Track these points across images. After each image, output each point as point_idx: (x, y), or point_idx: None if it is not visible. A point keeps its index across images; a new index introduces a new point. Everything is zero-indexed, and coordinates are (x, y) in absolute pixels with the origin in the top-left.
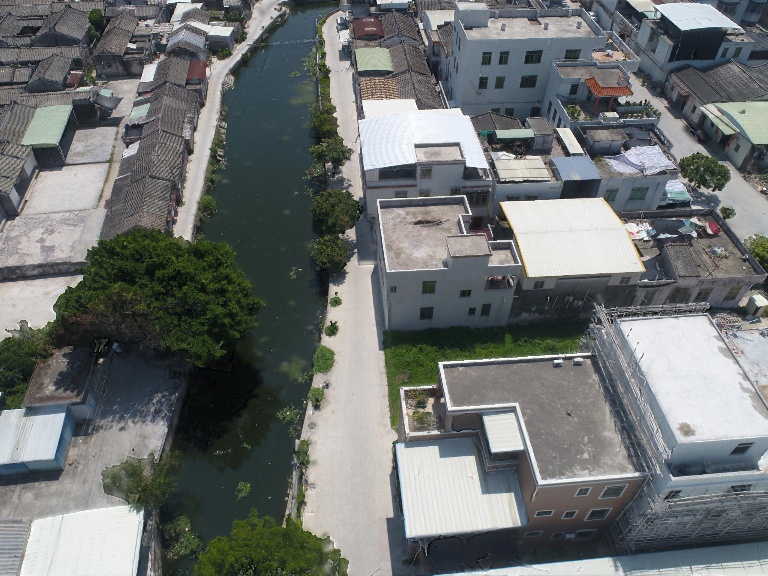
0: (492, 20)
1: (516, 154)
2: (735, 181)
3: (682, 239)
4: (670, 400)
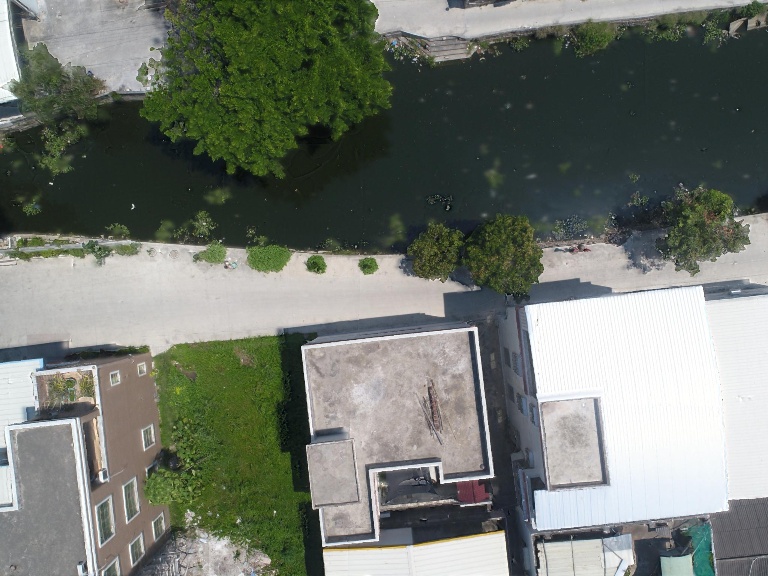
0: None
1: None
2: None
3: None
4: None
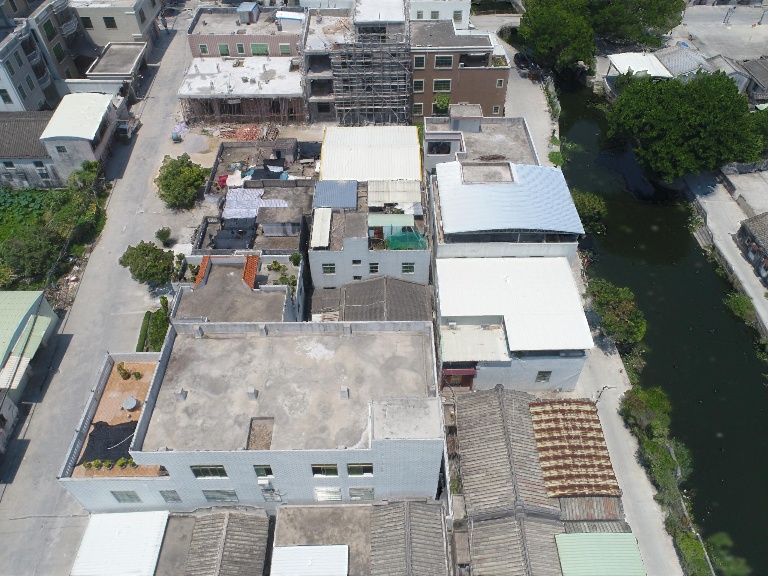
0: (355, 443)
1: None
2: (89, 298)
3: (266, 163)
4: (397, 2)
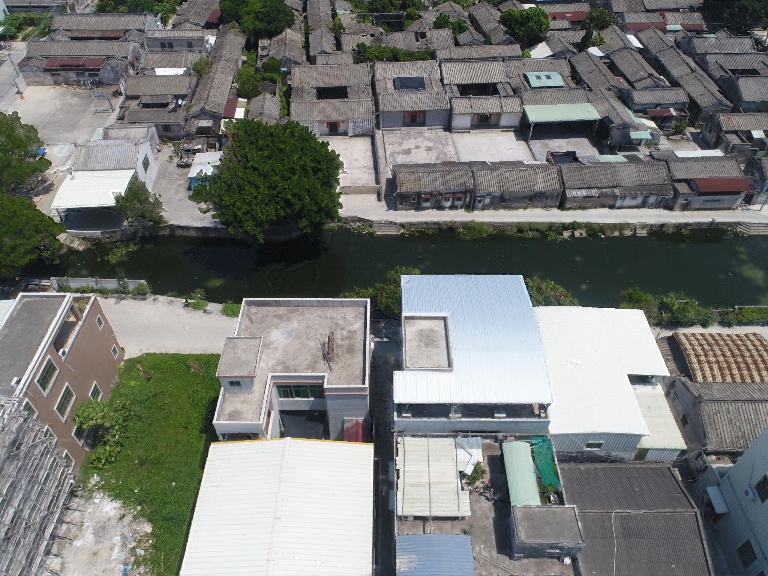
0: None
1: (496, 491)
2: None
3: None
4: None
